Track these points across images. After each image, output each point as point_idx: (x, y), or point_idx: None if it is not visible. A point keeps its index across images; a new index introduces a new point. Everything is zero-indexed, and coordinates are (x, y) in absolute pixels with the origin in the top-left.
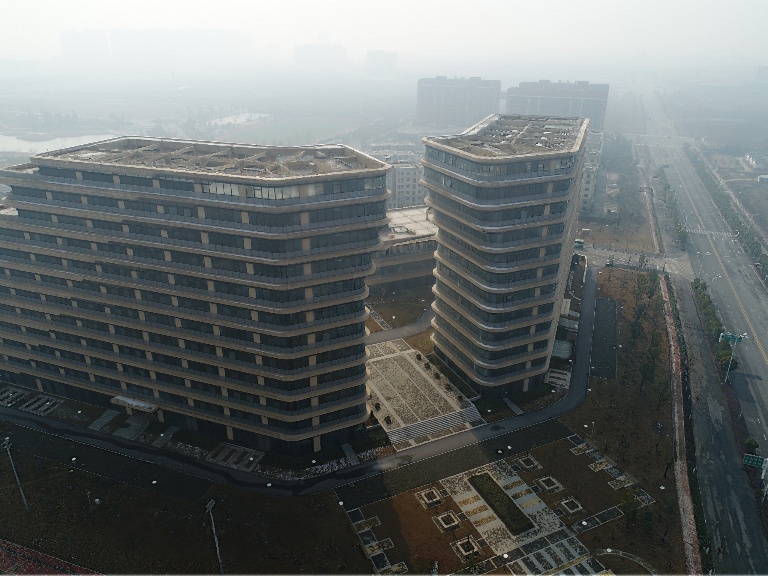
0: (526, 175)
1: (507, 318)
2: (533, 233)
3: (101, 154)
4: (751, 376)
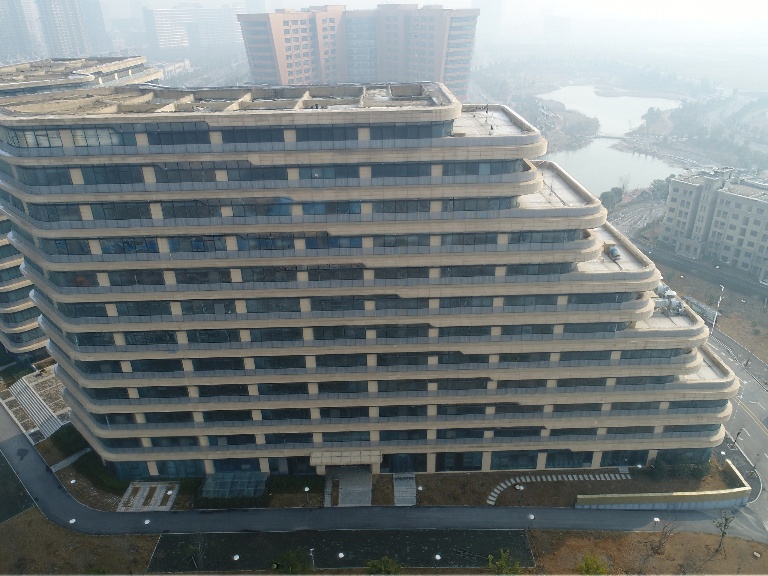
0: None
1: None
2: None
3: None
4: None
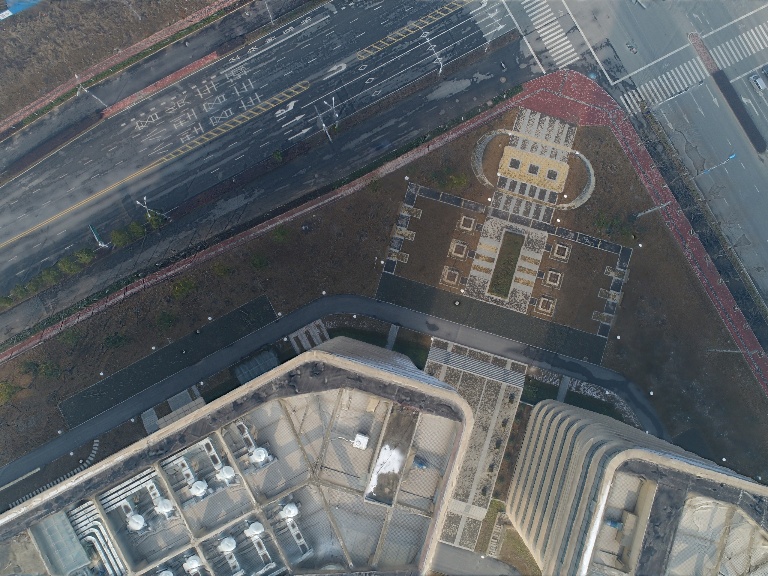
0: None
1: None
2: None
3: None
4: (129, 206)
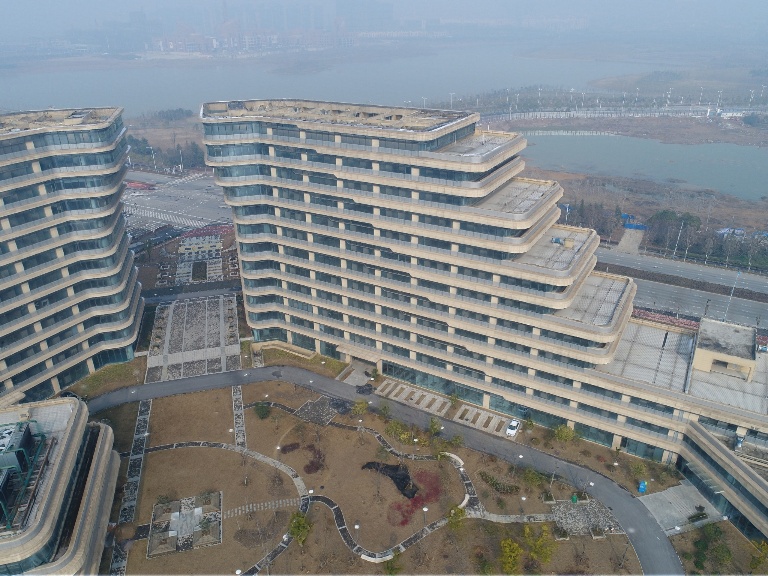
0: None
1: None
2: None
3: (424, 117)
4: None
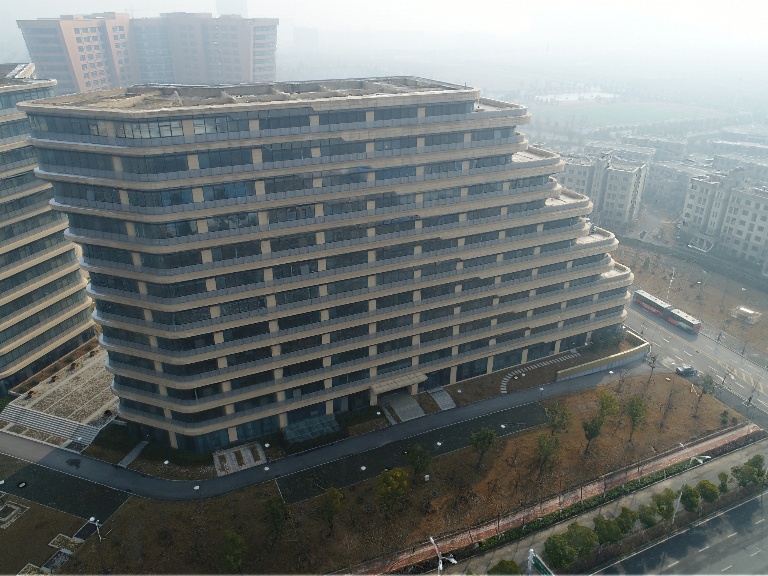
0: (75, 137)
1: (116, 335)
2: (115, 227)
3: None
4: None
